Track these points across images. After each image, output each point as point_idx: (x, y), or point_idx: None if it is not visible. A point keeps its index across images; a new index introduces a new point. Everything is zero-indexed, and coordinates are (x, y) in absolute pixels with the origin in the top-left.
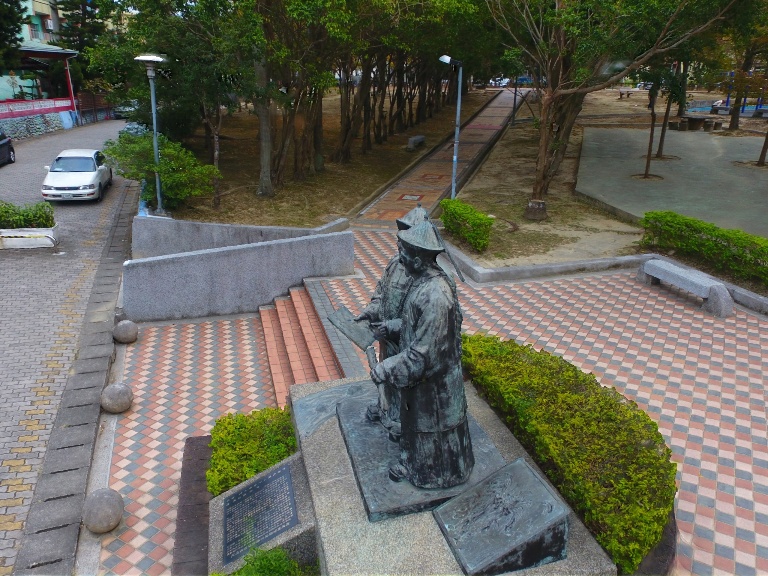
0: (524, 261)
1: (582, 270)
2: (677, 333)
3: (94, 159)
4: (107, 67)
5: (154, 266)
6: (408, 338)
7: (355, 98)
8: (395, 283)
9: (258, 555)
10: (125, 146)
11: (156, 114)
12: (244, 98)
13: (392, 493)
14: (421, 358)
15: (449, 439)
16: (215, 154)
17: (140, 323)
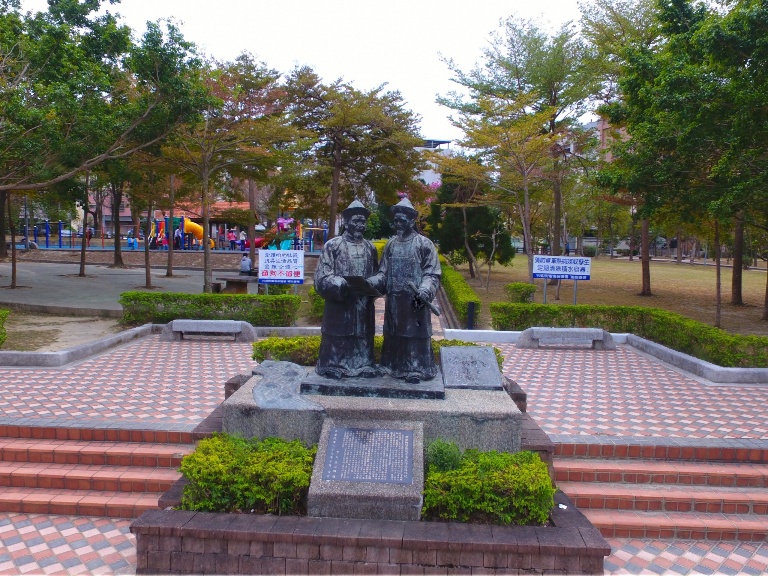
0: (56, 348)
1: (120, 342)
2: None
3: None
4: None
5: None
6: (416, 274)
7: None
8: (356, 255)
9: None
10: None
11: None
12: None
13: None
14: None
15: None
16: None
17: None
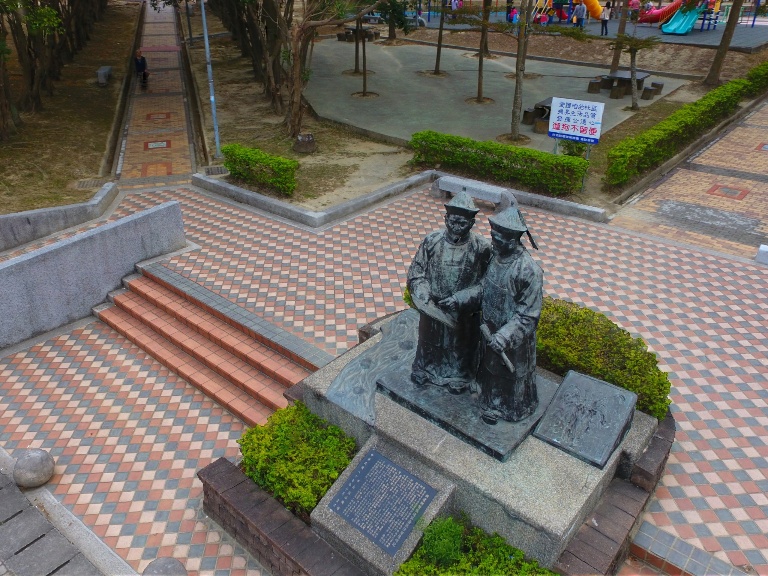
0: (334, 197)
1: (388, 196)
2: None
3: None
4: None
5: None
6: (507, 307)
7: (28, 28)
8: (450, 261)
9: (437, 531)
10: None
11: None
12: None
13: (501, 434)
14: (532, 321)
15: (533, 376)
16: None
17: None
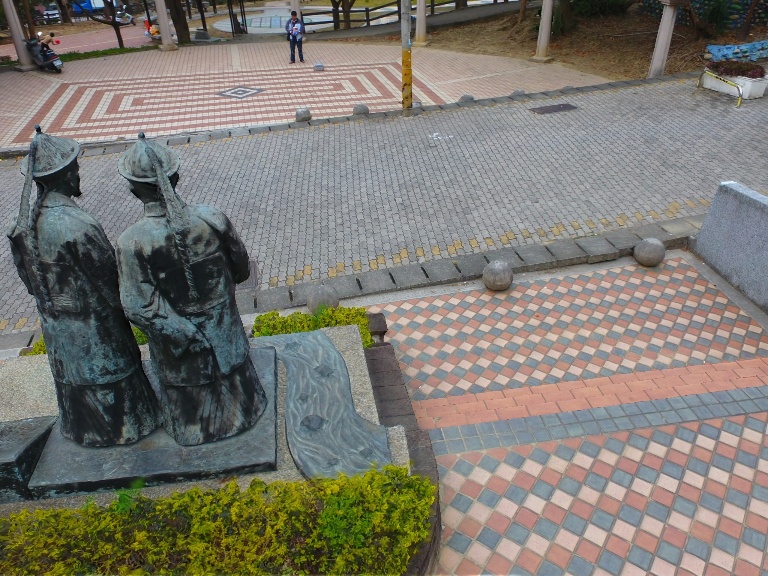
0: None
1: None
2: None
3: None
4: None
5: (744, 203)
6: None
7: None
8: None
9: None
10: None
11: None
12: None
13: None
14: None
15: None
16: None
17: (701, 261)
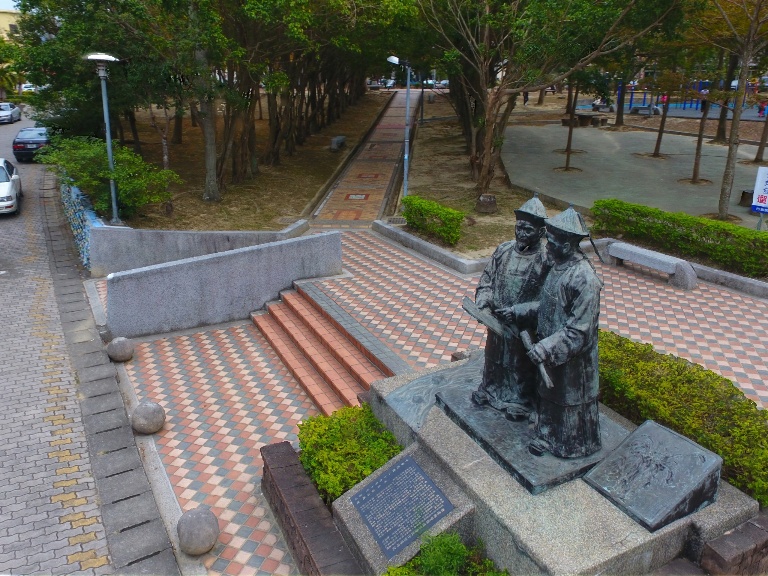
0: None
1: None
2: (661, 306)
3: (5, 168)
4: (34, 67)
5: (141, 278)
6: (557, 319)
7: (281, 99)
8: (514, 270)
9: (435, 542)
10: (71, 152)
11: (72, 118)
12: (194, 99)
13: (542, 466)
14: (581, 335)
15: (591, 410)
16: (165, 158)
17: None
